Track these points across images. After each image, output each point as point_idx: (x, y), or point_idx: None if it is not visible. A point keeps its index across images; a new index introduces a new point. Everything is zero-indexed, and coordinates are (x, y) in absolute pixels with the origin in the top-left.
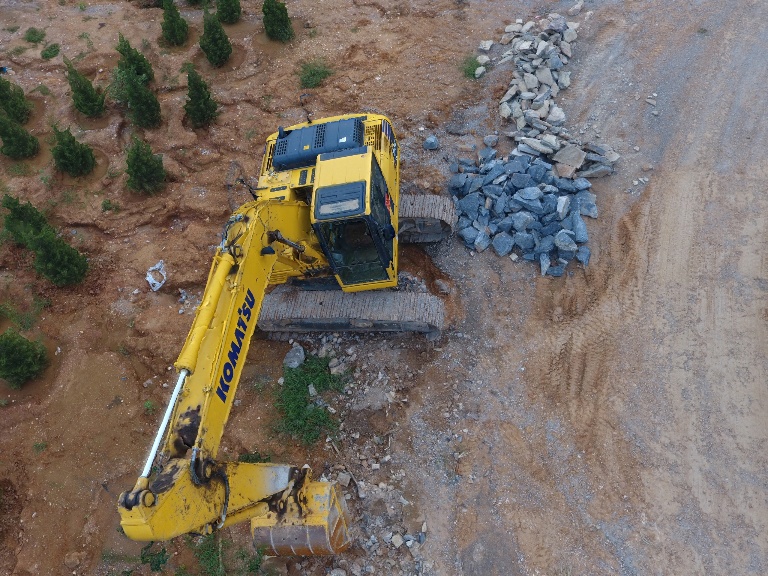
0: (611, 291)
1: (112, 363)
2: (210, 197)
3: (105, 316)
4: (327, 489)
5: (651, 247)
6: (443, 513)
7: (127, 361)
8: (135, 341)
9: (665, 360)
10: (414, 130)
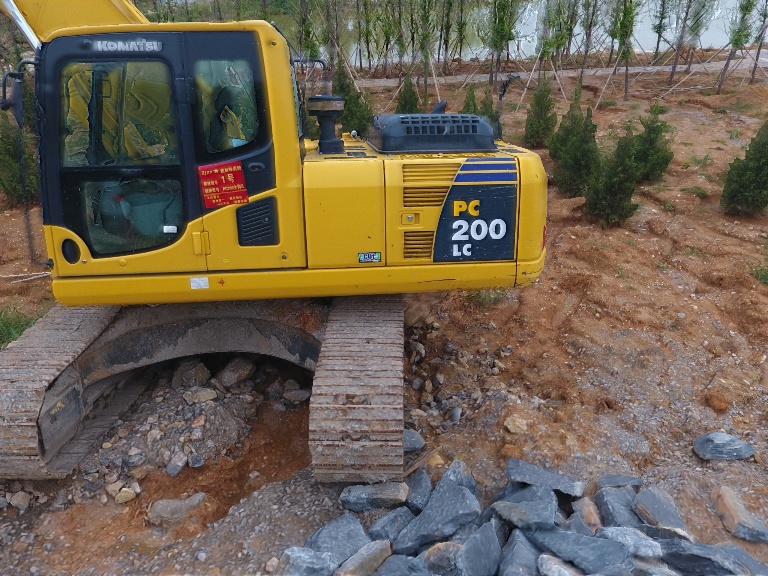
0: None
1: None
2: None
3: None
4: None
5: None
6: None
7: None
8: None
9: None
10: (765, 429)
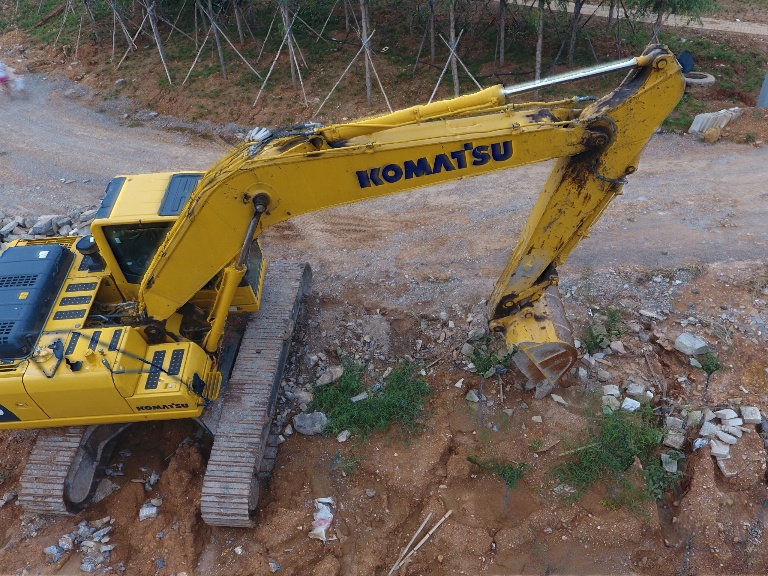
0: None
1: None
2: None
3: None
4: None
5: None
6: (487, 282)
7: None
8: None
9: None
10: None
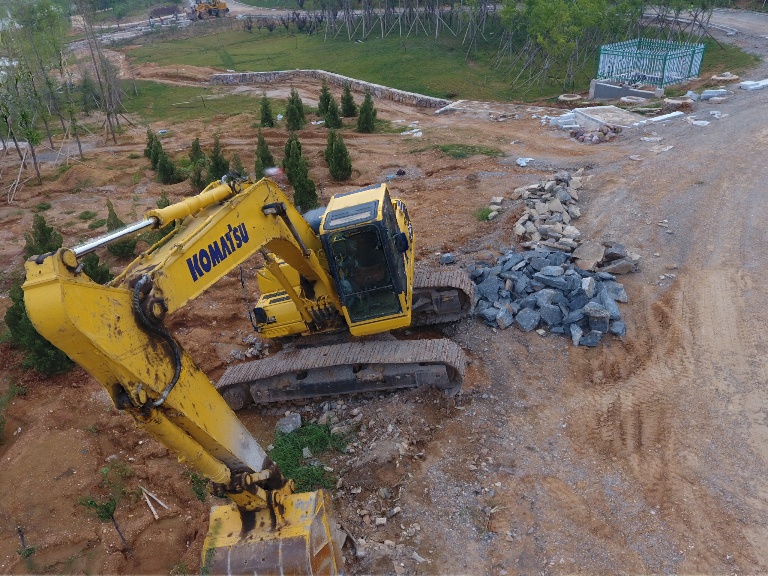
0: (656, 358)
1: (75, 438)
2: (220, 307)
3: (82, 402)
4: (313, 493)
5: (693, 324)
6: (473, 573)
7: (93, 438)
8: (108, 418)
9: (739, 417)
10: (430, 256)
